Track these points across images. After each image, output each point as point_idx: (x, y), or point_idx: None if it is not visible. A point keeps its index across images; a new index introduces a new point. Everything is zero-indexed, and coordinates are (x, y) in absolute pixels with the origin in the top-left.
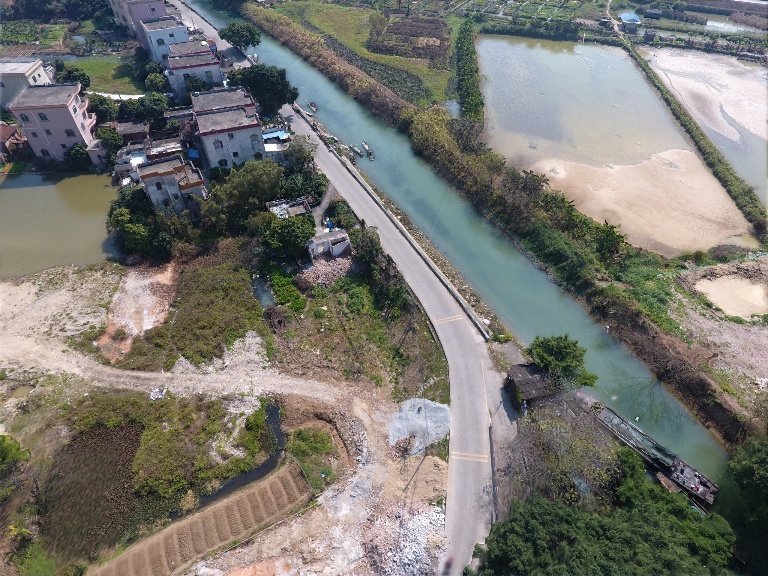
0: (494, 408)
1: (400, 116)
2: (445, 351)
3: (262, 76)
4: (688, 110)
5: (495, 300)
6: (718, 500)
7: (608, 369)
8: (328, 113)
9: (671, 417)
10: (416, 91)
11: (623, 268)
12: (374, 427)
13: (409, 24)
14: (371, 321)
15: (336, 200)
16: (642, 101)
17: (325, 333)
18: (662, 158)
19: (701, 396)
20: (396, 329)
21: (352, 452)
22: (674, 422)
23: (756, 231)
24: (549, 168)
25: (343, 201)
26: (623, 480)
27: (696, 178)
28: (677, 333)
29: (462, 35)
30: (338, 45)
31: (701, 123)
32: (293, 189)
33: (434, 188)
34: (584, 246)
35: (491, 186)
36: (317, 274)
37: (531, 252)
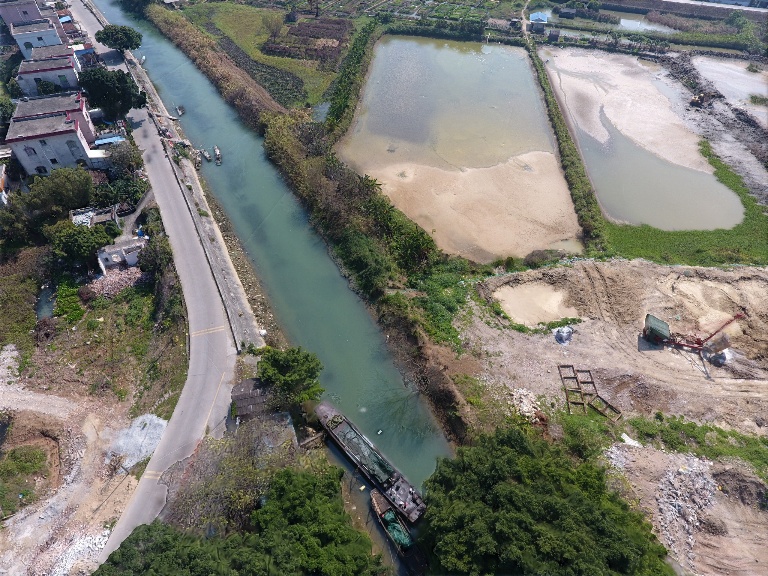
0: (214, 424)
1: (258, 120)
2: (190, 364)
3: (95, 81)
4: (566, 111)
5: (286, 309)
6: (422, 517)
7: (371, 380)
8: (194, 117)
9: (416, 430)
10: (294, 94)
11: (426, 275)
12: (96, 444)
13: (313, 25)
14: (142, 333)
15: (149, 207)
16: (523, 102)
17: (90, 346)
18: (519, 161)
19: (448, 408)
20: (162, 341)
21: (63, 471)
22: (417, 435)
23: (583, 235)
24: (399, 172)
25: (156, 208)
26: (262, 502)
27: (545, 181)
28: (450, 342)
29: (358, 36)
30: (233, 47)
31: (574, 124)
32: (108, 196)
33: (270, 193)
34: (388, 253)
35: (319, 191)
36: (103, 284)
37: (340, 259)
